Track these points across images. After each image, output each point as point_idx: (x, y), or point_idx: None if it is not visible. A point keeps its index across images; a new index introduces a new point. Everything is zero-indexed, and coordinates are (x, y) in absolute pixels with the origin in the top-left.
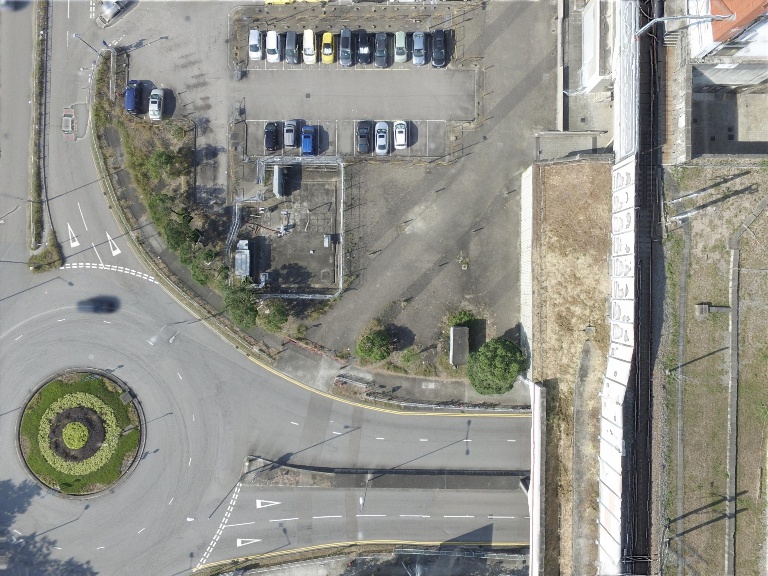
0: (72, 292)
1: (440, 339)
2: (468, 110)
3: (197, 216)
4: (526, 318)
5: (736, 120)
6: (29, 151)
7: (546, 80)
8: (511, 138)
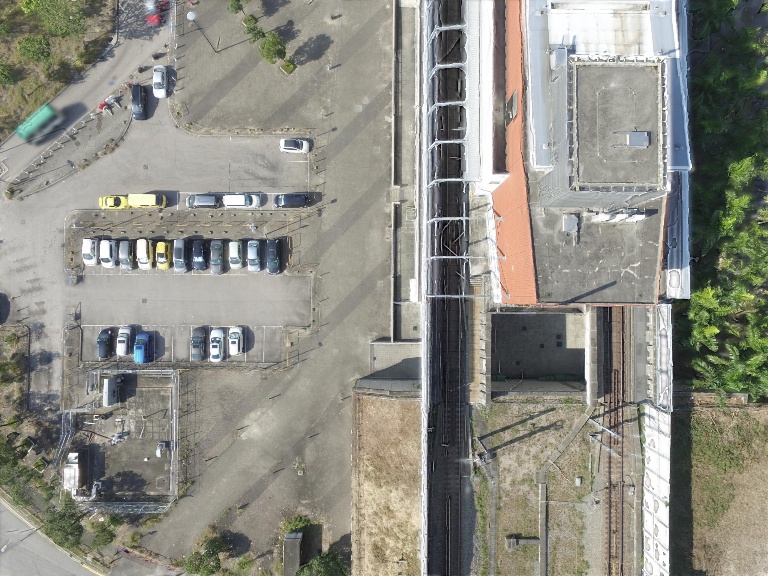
0: None
1: (276, 545)
2: (304, 316)
3: (30, 423)
4: None
5: (564, 328)
6: None
7: (380, 287)
8: (346, 344)
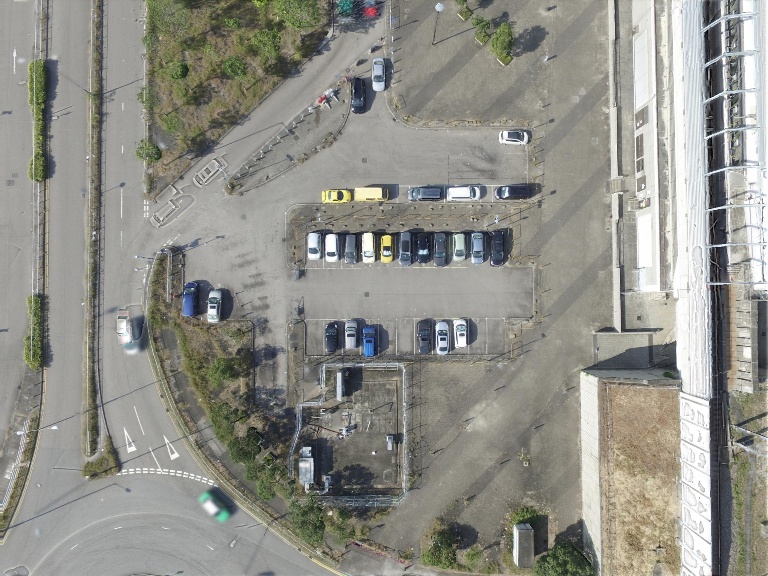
0: (129, 498)
1: (503, 536)
2: (526, 307)
3: (257, 418)
4: (591, 523)
5: None
6: (83, 355)
7: (602, 277)
8: (569, 335)
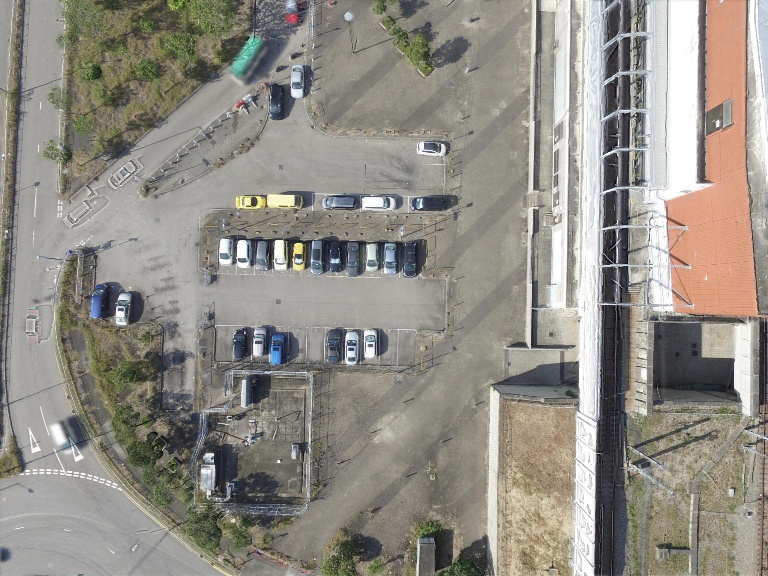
0: (32, 499)
1: (407, 549)
2: (438, 320)
3: (163, 423)
4: (492, 540)
5: (700, 337)
6: None
7: (516, 292)
8: (480, 349)
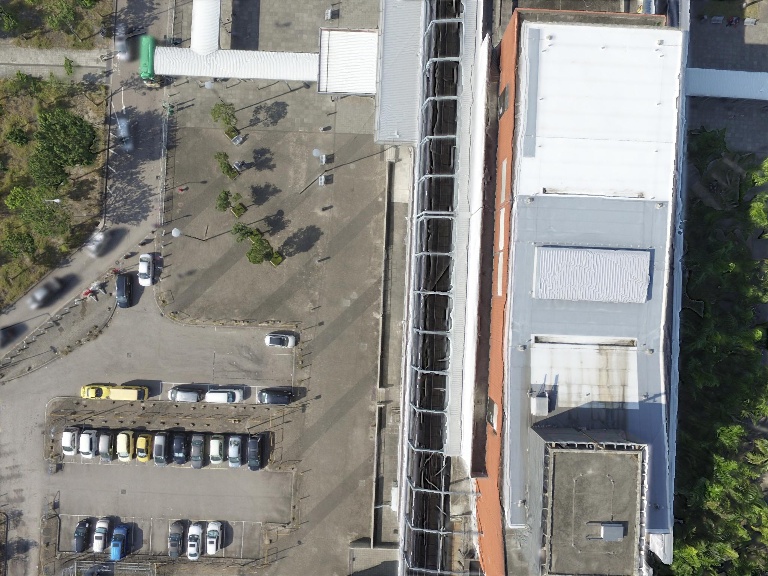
0: None
1: None
2: (284, 513)
3: None
4: None
5: None
6: None
7: (362, 487)
8: (325, 544)
